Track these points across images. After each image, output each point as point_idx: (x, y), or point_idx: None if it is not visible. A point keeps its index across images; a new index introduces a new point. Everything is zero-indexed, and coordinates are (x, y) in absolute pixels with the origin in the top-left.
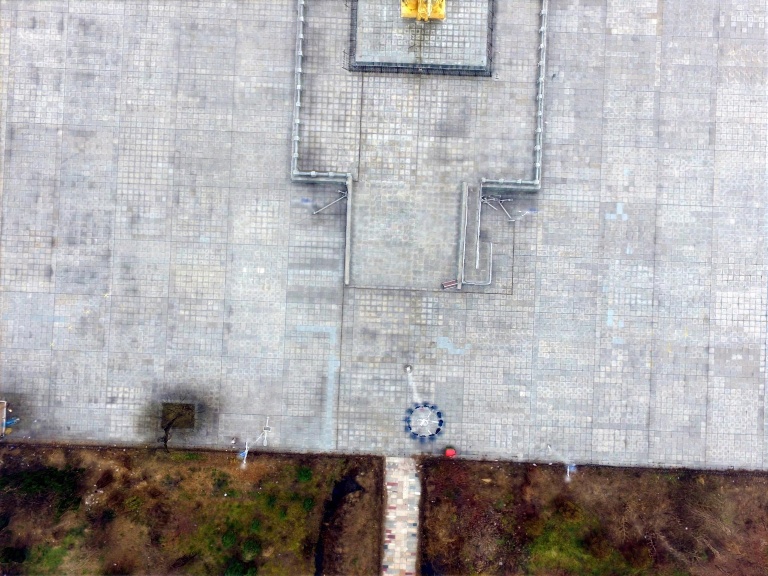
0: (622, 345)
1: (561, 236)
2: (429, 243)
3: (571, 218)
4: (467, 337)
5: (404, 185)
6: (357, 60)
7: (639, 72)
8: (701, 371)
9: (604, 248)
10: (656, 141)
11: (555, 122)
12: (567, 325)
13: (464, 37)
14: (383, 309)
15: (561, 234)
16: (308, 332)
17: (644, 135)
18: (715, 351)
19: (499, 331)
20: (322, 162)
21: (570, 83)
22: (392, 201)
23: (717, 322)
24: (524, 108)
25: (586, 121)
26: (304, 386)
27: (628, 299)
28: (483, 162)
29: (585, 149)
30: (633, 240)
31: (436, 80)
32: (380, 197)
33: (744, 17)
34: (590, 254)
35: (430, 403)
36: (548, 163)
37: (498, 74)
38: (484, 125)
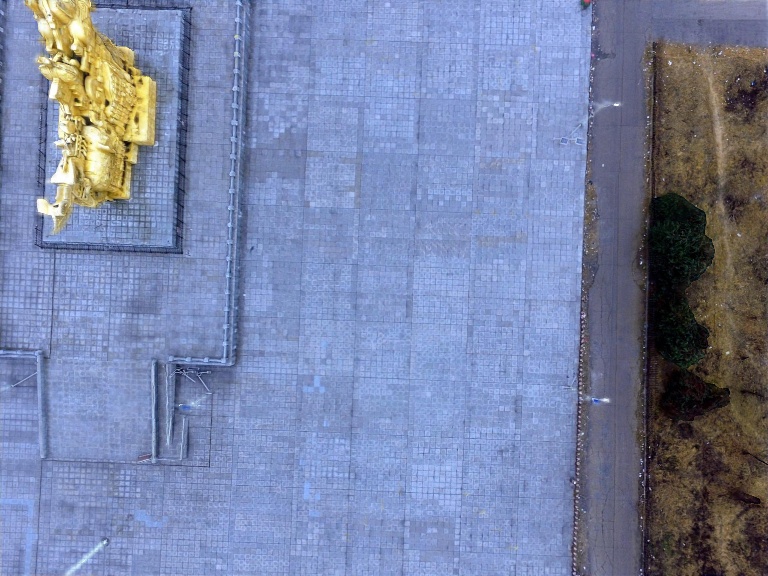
0: (318, 518)
1: (259, 409)
2: (124, 417)
3: (269, 391)
4: (164, 510)
5: (96, 362)
6: (44, 240)
7: (337, 245)
8: (396, 544)
9: (301, 421)
10: (353, 314)
11: (253, 295)
12: (264, 498)
13: (151, 217)
14: (81, 482)
15: (259, 407)
16: (6, 505)
17: (342, 308)
18: (410, 524)
19: (196, 504)
20: (14, 339)
21: (268, 256)
22: (85, 377)
23: (413, 495)
24: (215, 285)
25: (284, 294)
26: (2, 559)
27: (325, 472)
28: (174, 339)
29: (283, 322)
30: (330, 413)
31: (128, 257)
32: (73, 373)
33: (441, 190)
34: (287, 427)
35: (127, 575)
36: (246, 336)
37: (190, 251)
38: (176, 302)
